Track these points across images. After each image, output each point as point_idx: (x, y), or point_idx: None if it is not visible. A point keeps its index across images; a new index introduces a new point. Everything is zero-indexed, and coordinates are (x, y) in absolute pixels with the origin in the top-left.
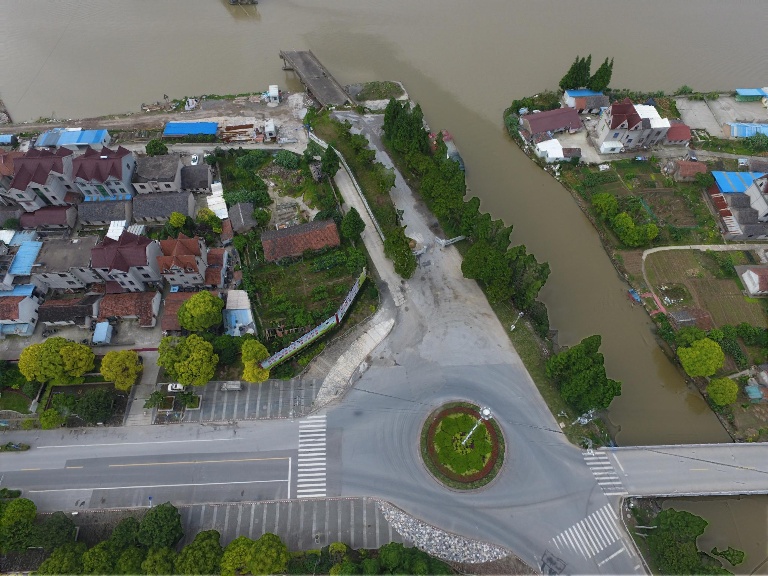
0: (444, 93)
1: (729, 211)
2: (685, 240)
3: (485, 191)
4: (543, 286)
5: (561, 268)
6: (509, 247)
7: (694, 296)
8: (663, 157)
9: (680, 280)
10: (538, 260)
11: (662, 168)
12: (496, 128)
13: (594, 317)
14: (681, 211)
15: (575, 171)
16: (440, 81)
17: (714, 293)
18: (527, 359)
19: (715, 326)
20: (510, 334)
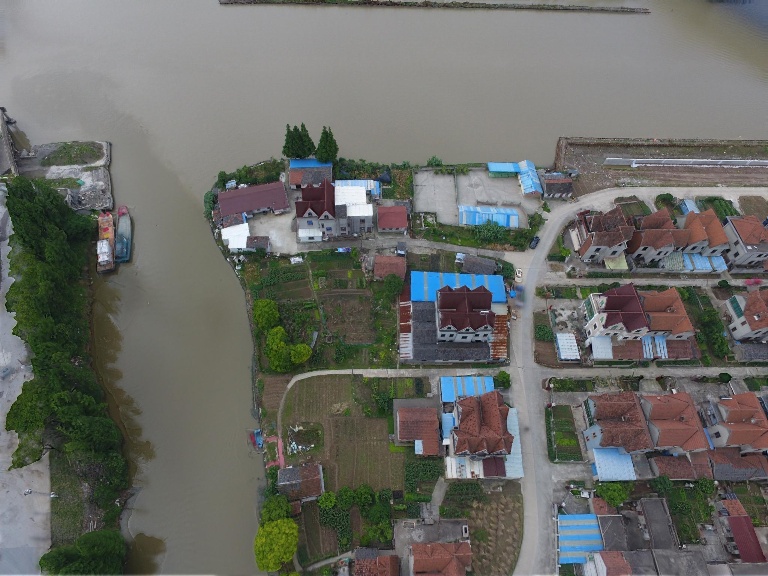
0: (155, 157)
1: (410, 326)
2: (351, 361)
3: (167, 281)
4: (190, 410)
5: (210, 389)
6: (172, 355)
7: (327, 442)
8: (373, 248)
9: (320, 419)
10: (194, 375)
11: (365, 262)
12: (196, 204)
13: (219, 460)
14: (364, 321)
15: (260, 264)
16: (158, 142)
17: (354, 438)
18: (58, 540)
19: (336, 486)
20: (54, 502)
